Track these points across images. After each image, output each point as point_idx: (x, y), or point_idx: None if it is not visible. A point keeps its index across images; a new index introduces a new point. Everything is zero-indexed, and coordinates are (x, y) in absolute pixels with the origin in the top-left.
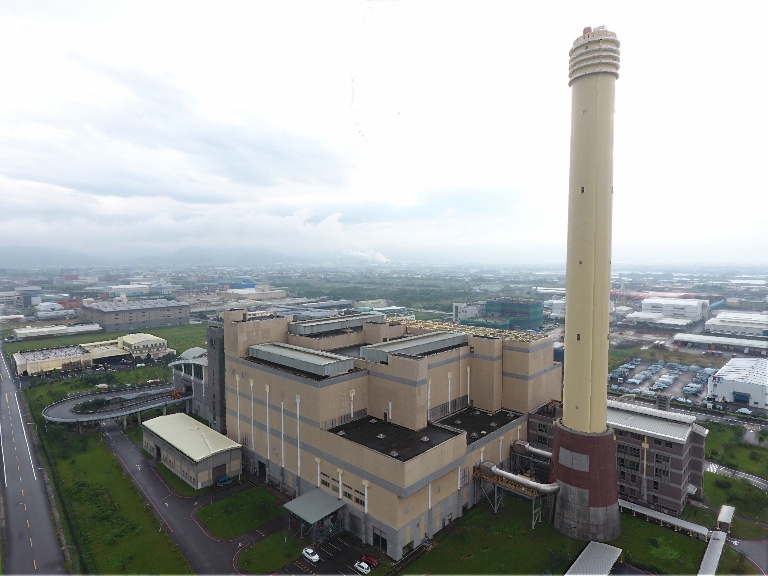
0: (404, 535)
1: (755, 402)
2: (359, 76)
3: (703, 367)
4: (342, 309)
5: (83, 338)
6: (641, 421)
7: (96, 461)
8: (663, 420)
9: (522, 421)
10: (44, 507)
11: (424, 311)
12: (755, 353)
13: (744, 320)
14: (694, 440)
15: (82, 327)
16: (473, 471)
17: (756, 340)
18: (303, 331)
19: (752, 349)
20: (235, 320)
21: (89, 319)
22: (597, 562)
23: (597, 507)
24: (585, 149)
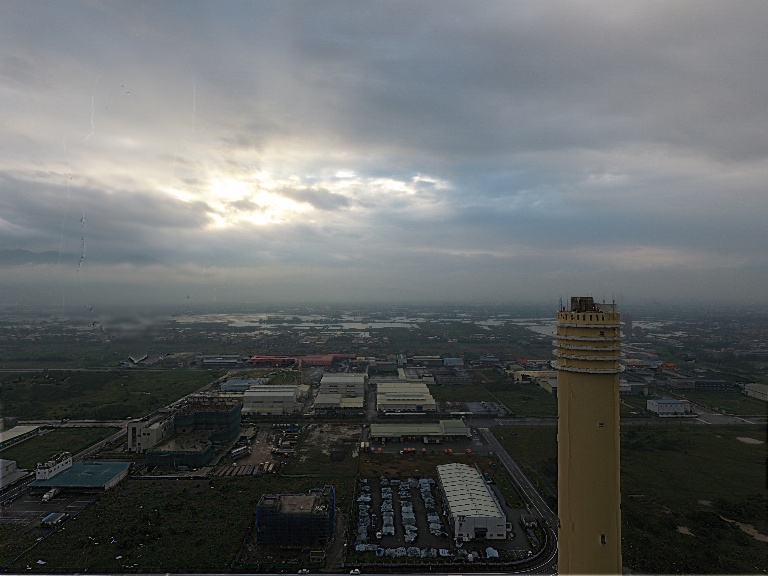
0: None
1: (491, 534)
2: (96, 213)
3: (417, 478)
4: None
5: None
6: None
7: None
8: None
9: None
10: None
11: (71, 426)
12: (432, 442)
13: (401, 396)
14: None
15: None
16: None
17: (427, 426)
18: None
19: (430, 438)
20: None
21: None
22: None
23: None
24: (604, 479)
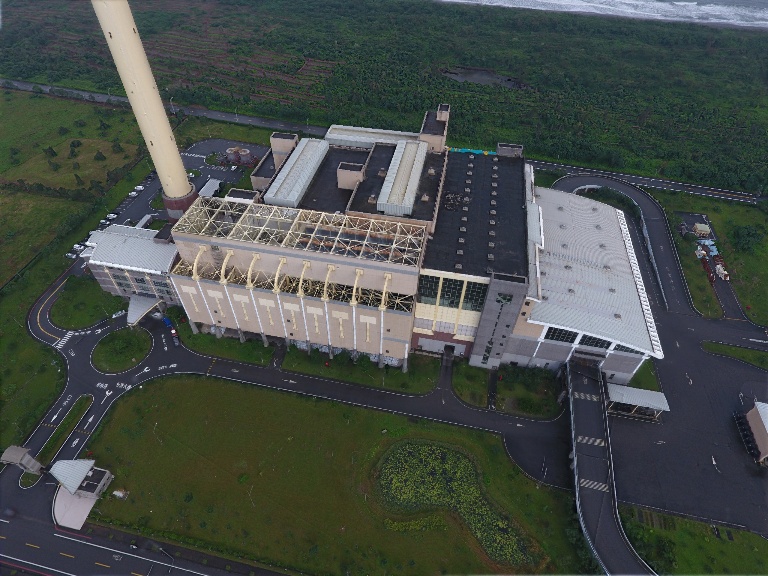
0: None
1: None
2: None
3: None
4: None
5: None
6: (131, 233)
7: None
8: None
9: None
10: None
11: None
12: None
13: None
14: None
15: None
16: None
17: None
18: None
19: None
20: None
21: None
22: None
23: None
24: None
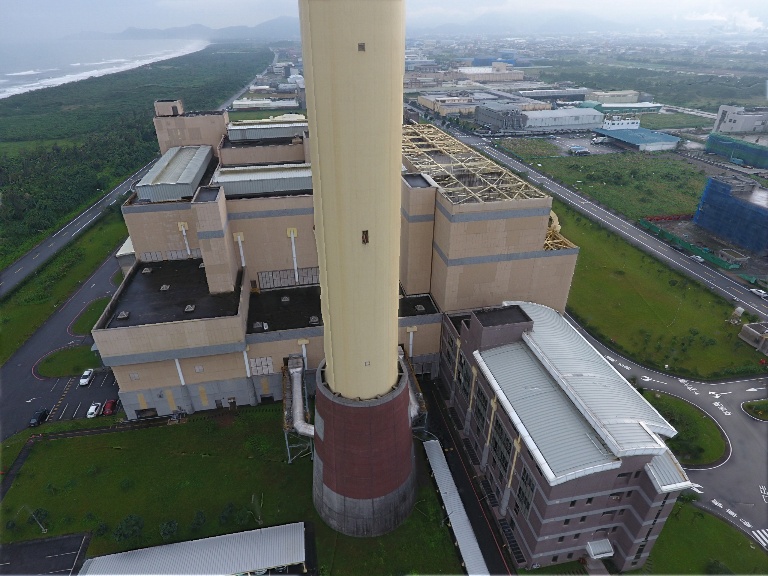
0: (134, 400)
1: None
2: None
3: None
4: (571, 101)
5: (278, 113)
6: (543, 403)
7: (114, 232)
8: (585, 422)
9: (425, 321)
10: (42, 260)
11: (692, 113)
12: None
13: None
14: (642, 484)
15: (282, 102)
16: (284, 363)
17: None
18: (229, 135)
19: None
20: (163, 114)
21: (298, 94)
22: (247, 553)
23: (331, 489)
24: None
